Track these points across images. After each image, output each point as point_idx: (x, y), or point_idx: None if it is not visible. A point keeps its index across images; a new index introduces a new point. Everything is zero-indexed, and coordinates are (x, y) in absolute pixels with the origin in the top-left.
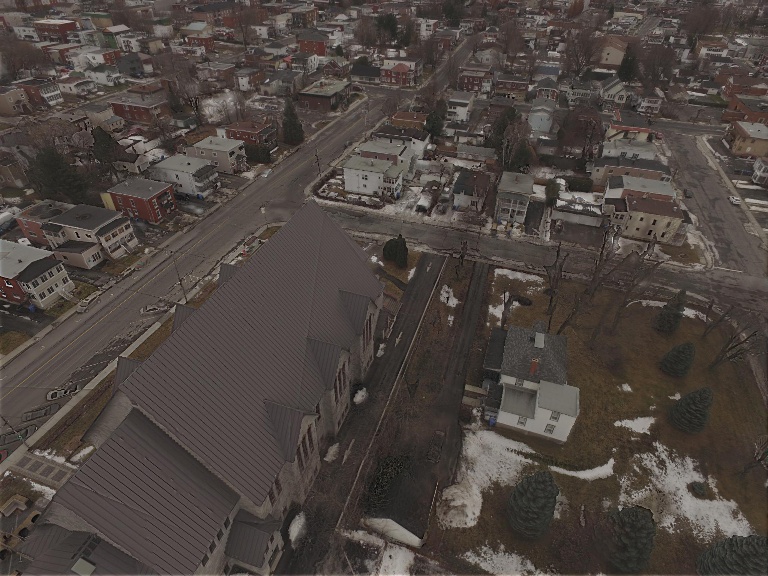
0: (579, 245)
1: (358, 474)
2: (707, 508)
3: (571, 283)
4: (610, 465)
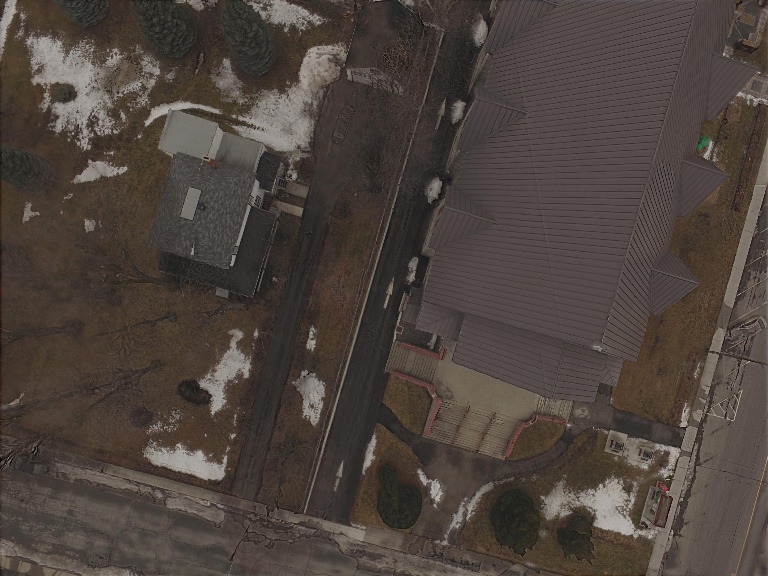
0: (45, 575)
1: (428, 86)
2: (66, 74)
3: (98, 447)
4: (151, 118)
